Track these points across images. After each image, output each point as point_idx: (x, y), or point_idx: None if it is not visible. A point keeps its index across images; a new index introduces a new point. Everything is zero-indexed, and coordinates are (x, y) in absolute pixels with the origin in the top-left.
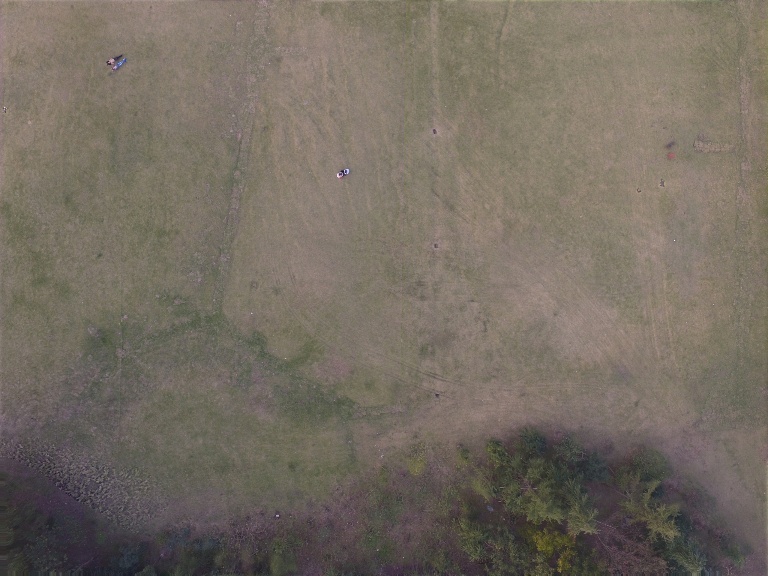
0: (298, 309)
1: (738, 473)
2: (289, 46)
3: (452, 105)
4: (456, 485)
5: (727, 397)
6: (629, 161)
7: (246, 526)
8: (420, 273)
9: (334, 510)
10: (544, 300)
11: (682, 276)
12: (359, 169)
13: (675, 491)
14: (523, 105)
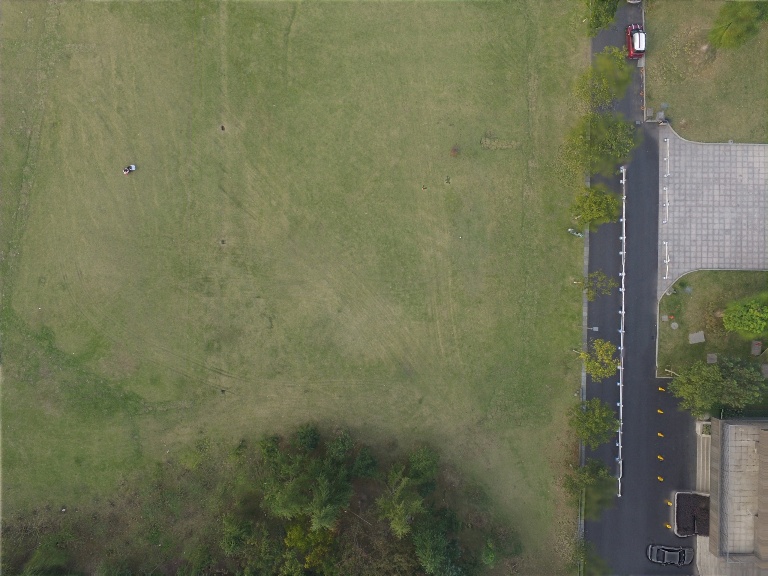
0: (85, 304)
1: (522, 471)
2: (79, 43)
3: (240, 102)
4: (234, 481)
5: (512, 395)
6: (415, 158)
7: (33, 520)
8: (207, 269)
9: (119, 505)
10: (328, 297)
11: (467, 273)
12: (146, 165)
13: (458, 488)
14: (310, 102)
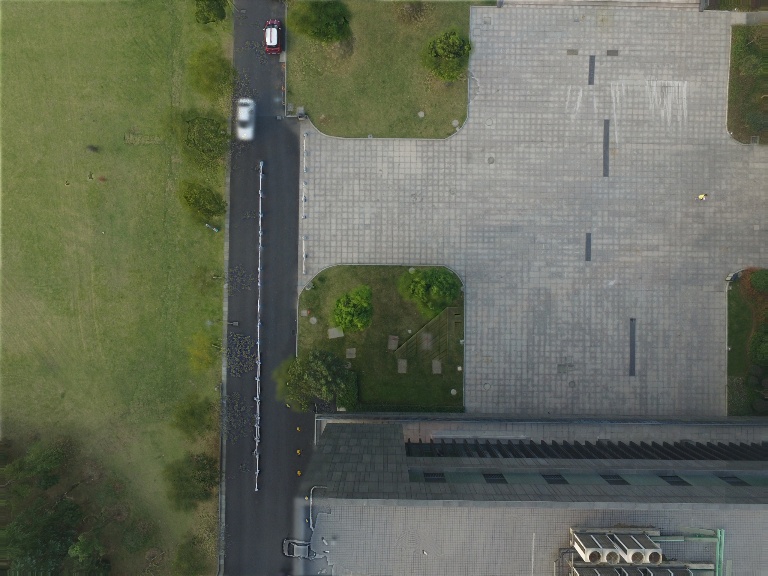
0: None
1: (162, 465)
2: None
3: None
4: None
5: (155, 389)
6: (58, 154)
7: None
8: None
9: None
10: None
11: (110, 268)
12: None
13: (98, 482)
14: None
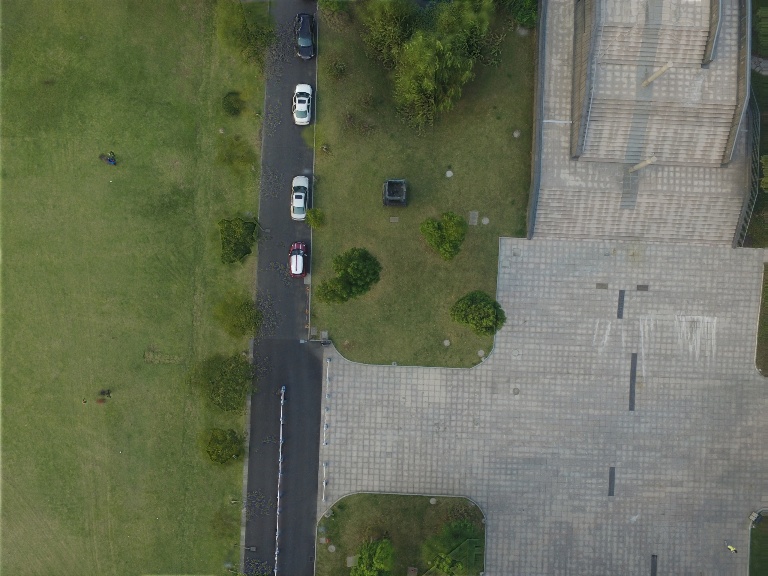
0: None
1: None
2: None
3: None
4: None
5: None
6: (76, 371)
7: None
8: None
9: None
10: None
11: (127, 488)
12: None
13: None
14: None
